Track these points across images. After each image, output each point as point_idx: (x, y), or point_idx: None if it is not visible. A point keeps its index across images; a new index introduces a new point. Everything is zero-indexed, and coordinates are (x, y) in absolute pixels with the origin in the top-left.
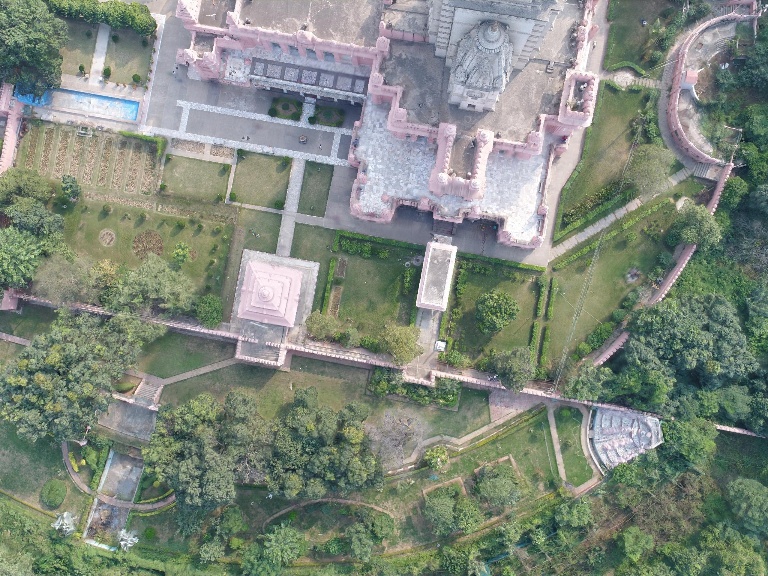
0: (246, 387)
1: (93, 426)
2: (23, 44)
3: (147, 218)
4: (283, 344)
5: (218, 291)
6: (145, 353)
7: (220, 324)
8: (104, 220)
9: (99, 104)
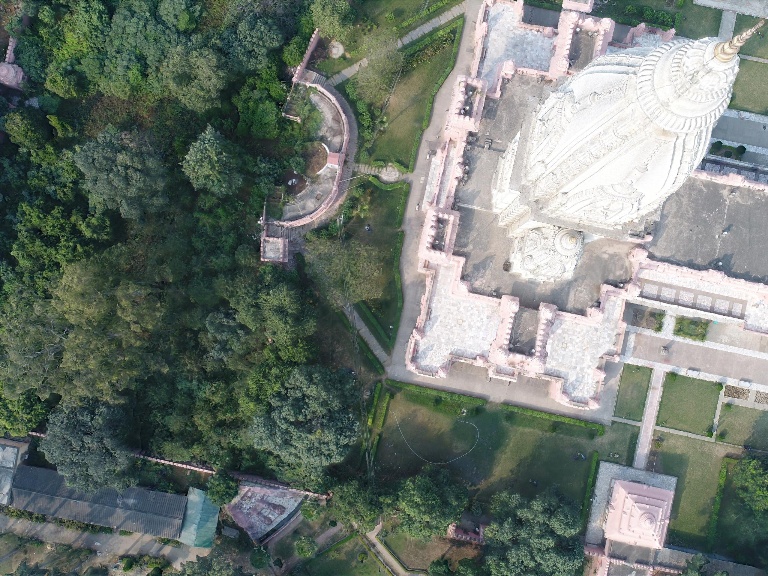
0: None
1: None
2: None
3: None
4: None
5: None
6: None
7: None
8: None
9: None
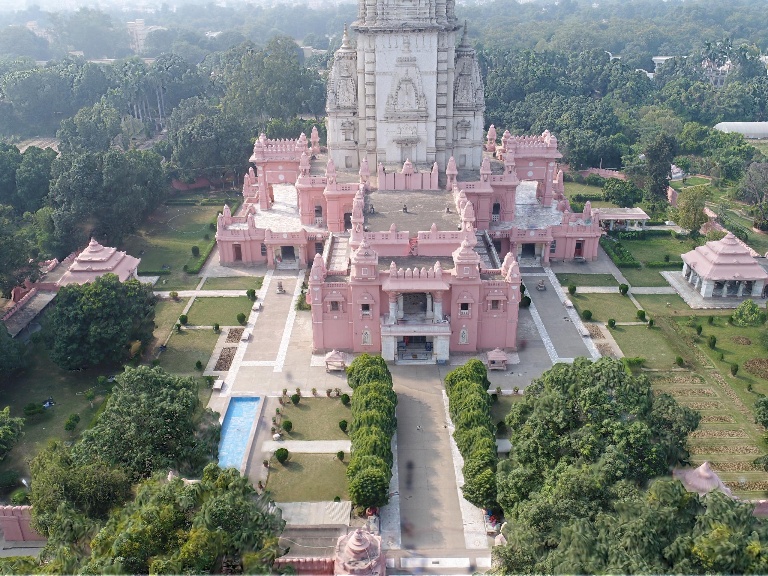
0: None
1: None
2: None
3: None
4: (765, 256)
5: None
6: None
7: None
8: None
9: None
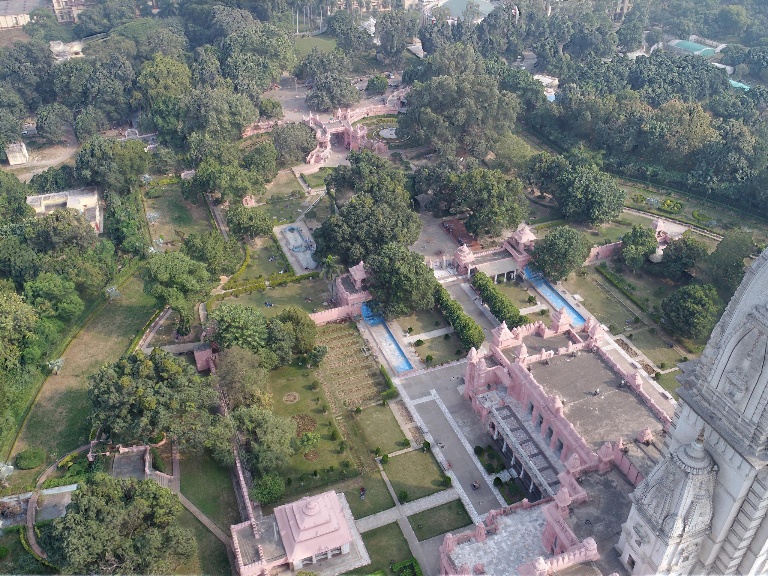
0: (202, 565)
1: (114, 429)
2: (401, 273)
3: (325, 414)
4: (267, 562)
5: (290, 492)
6: (200, 467)
7: (258, 509)
8: (305, 390)
9: (393, 350)
